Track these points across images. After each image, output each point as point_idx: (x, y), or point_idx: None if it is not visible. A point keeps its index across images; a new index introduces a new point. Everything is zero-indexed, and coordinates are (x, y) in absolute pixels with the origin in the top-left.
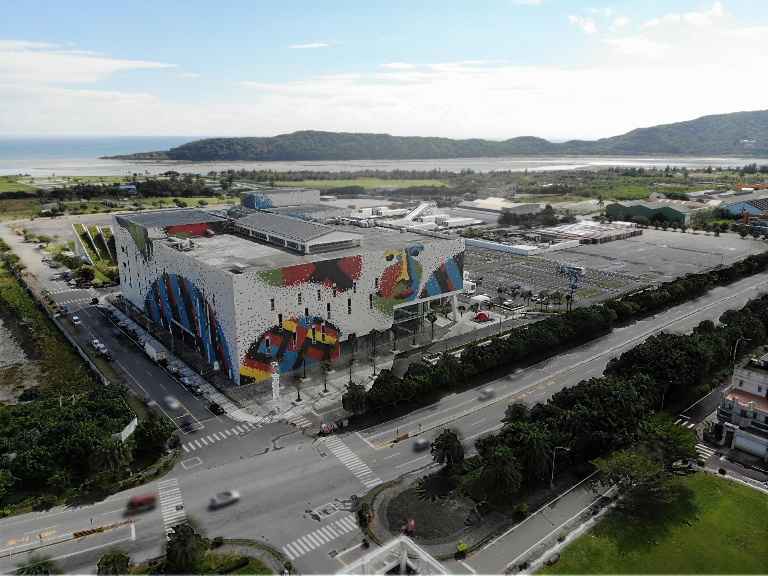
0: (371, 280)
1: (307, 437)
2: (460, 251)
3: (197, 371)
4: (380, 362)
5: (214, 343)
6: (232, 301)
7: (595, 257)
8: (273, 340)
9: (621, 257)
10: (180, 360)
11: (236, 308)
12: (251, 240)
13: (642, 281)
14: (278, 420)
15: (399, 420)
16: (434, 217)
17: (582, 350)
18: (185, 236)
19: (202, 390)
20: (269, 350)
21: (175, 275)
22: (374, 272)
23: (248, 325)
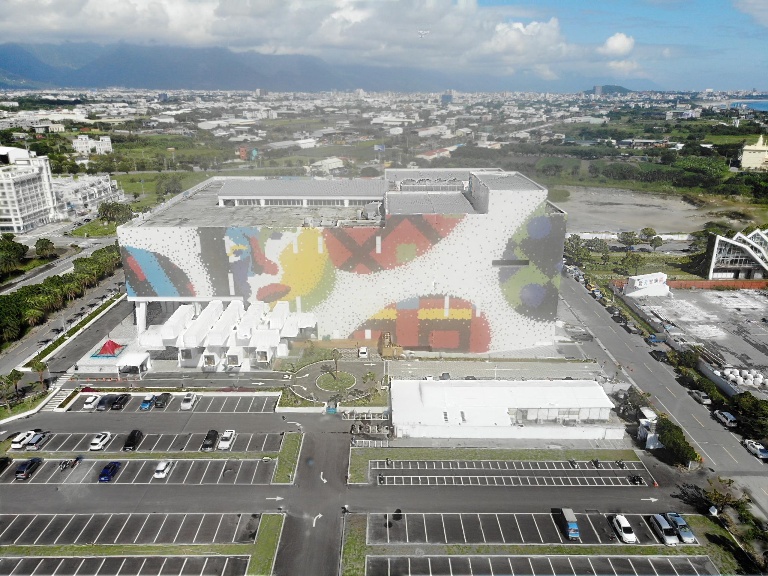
0: None
1: None
2: None
3: None
4: None
5: None
6: None
7: None
8: None
9: None
10: None
11: None
12: None
13: None
14: None
15: None
16: None
17: None
18: None
19: None
20: None
21: None
22: None
23: None
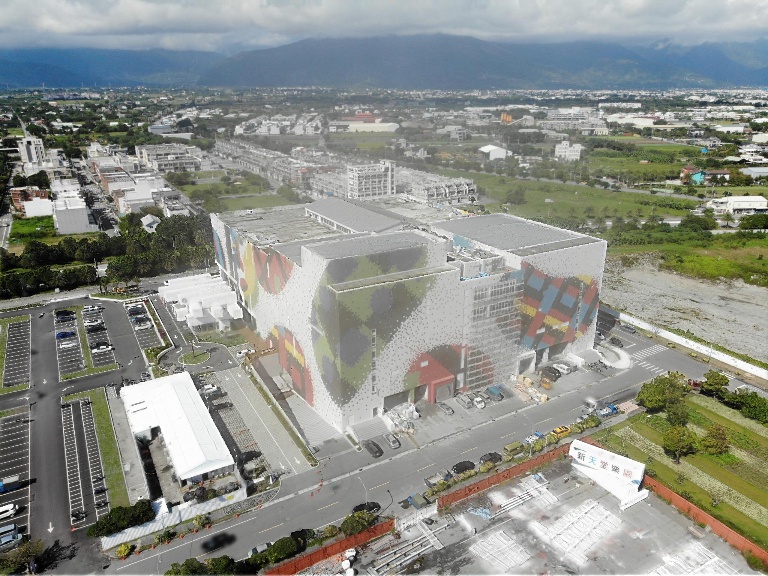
0: None
1: None
2: None
3: None
4: None
5: None
6: None
7: None
8: None
9: None
10: None
11: None
12: None
13: None
14: None
15: None
16: None
17: None
18: None
19: None
20: None
21: None
22: None
23: None
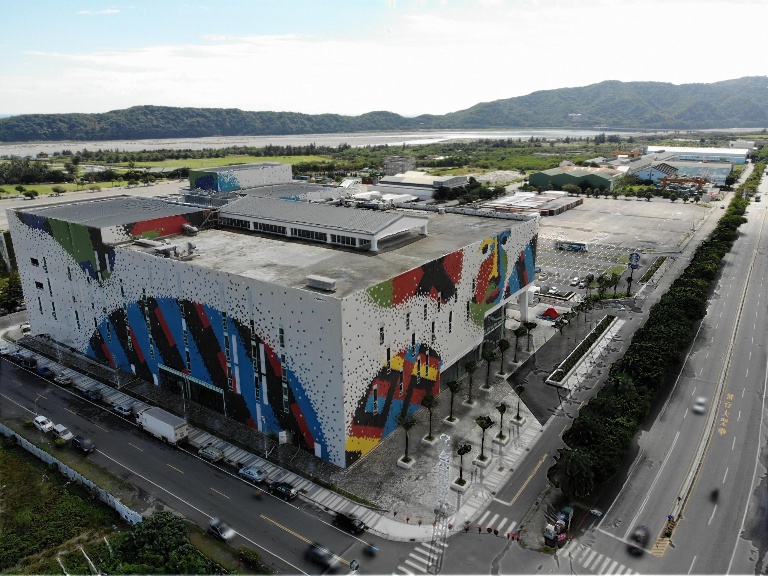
0: (469, 282)
1: (537, 554)
2: (535, 234)
3: (254, 451)
4: (500, 395)
5: (276, 403)
6: (336, 340)
7: (571, 230)
8: (380, 389)
9: (595, 228)
10: (209, 434)
11: (343, 350)
12: (263, 236)
13: (648, 253)
14: (461, 527)
15: (628, 492)
16: (367, 195)
17: (703, 344)
18: (154, 236)
19: (296, 490)
20: (376, 405)
21: (174, 300)
22: (472, 271)
23: (356, 374)
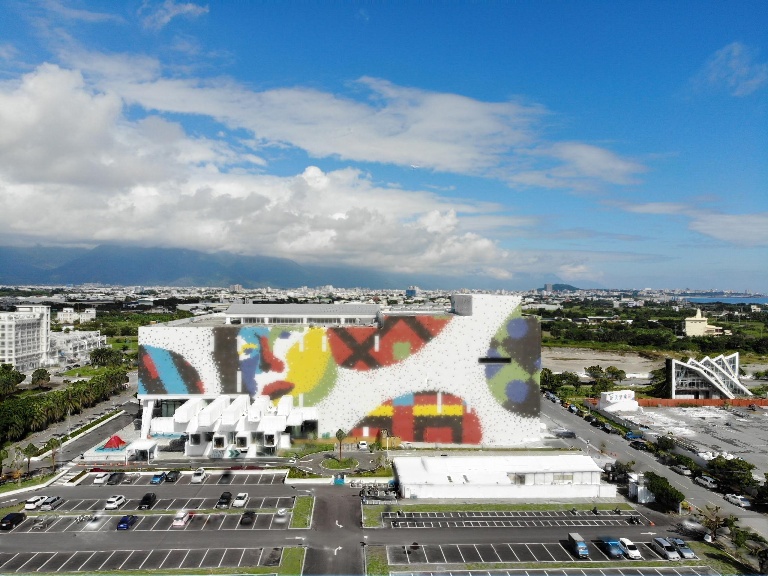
0: None
1: None
2: None
3: None
4: None
5: None
6: None
7: None
8: None
9: None
10: None
11: None
12: None
13: None
14: None
15: None
16: None
17: None
18: None
19: None
20: None
21: None
22: None
23: None
